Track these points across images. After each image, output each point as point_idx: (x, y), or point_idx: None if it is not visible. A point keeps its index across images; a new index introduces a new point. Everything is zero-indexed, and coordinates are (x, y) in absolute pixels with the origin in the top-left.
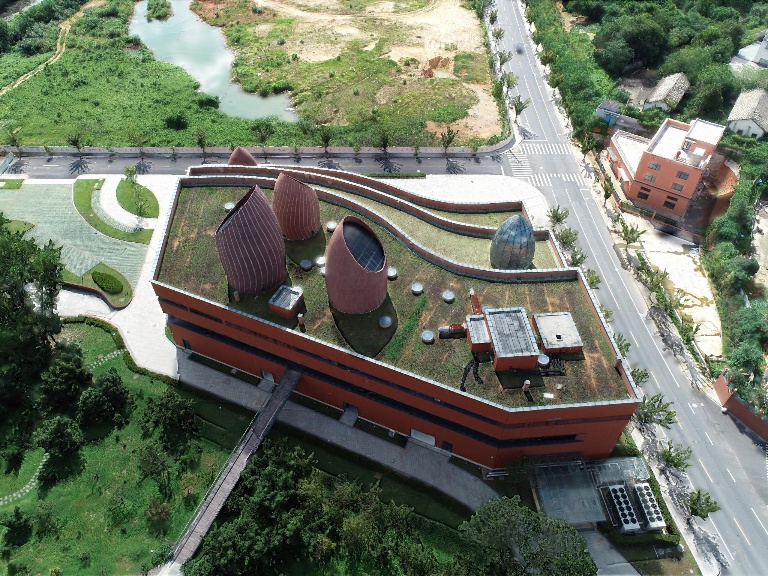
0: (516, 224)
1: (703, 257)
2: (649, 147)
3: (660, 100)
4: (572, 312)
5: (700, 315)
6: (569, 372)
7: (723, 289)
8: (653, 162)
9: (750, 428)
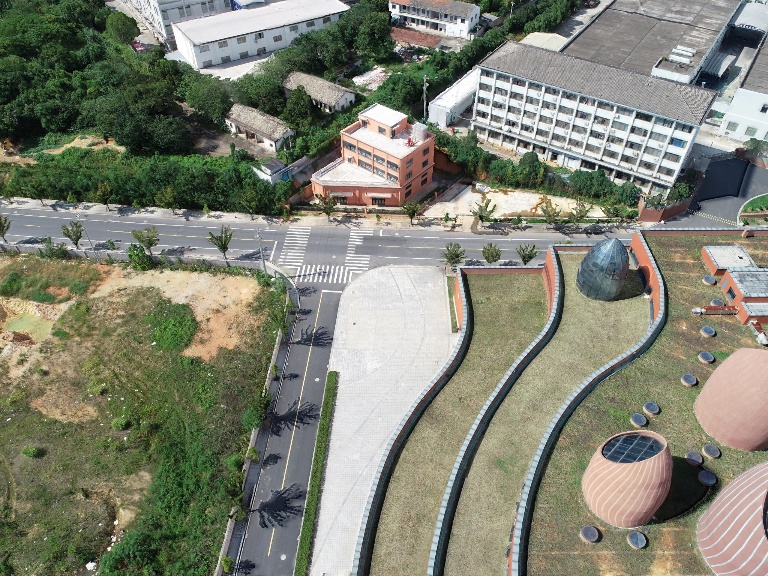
0: (622, 246)
1: (490, 185)
2: (389, 155)
3: (286, 130)
4: (689, 248)
5: (562, 207)
6: (766, 264)
7: (544, 183)
8: (407, 161)
9: (676, 215)
